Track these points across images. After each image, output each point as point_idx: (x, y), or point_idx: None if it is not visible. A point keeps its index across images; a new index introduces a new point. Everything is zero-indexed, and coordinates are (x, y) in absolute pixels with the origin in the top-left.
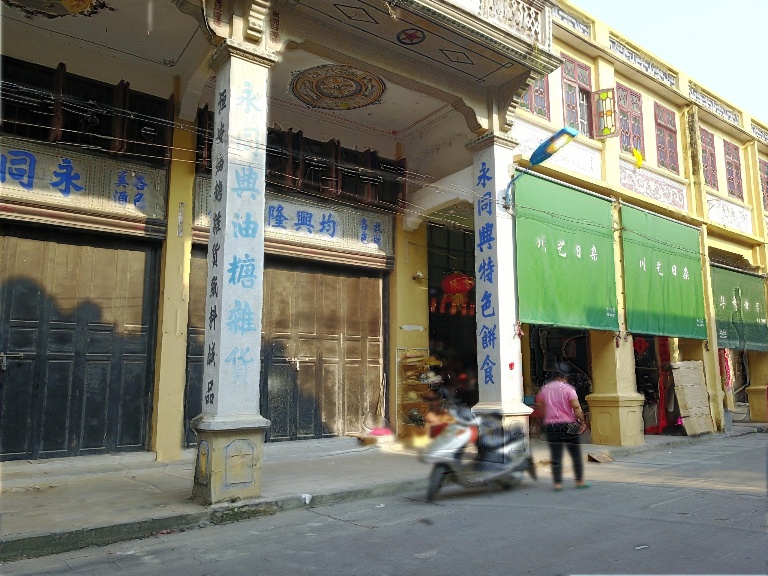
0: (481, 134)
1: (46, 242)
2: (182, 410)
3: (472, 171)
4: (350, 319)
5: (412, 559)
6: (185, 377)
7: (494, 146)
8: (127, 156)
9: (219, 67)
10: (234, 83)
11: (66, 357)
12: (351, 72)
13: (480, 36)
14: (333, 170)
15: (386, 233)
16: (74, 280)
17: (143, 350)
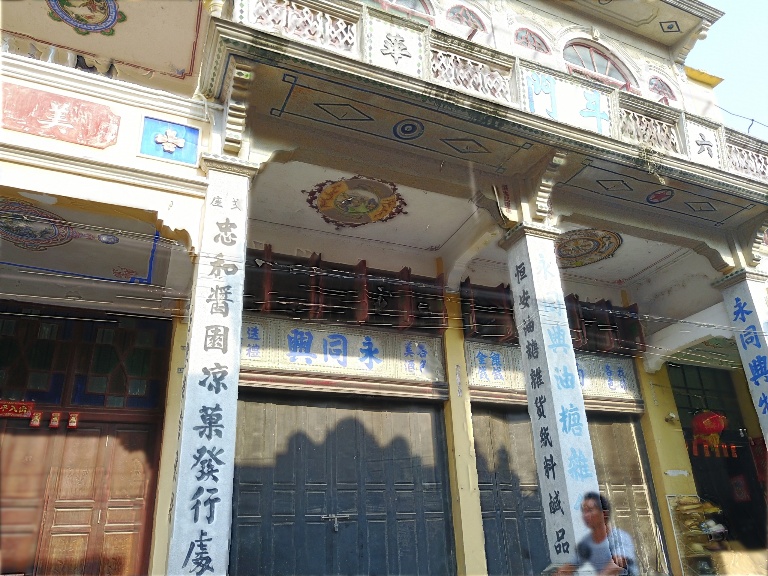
0: (728, 272)
1: (356, 411)
2: (486, 568)
3: (723, 307)
4: (611, 467)
5: None
6: (483, 533)
7: (747, 281)
8: (411, 329)
9: (511, 245)
10: (532, 256)
11: (381, 517)
12: (593, 234)
13: (725, 186)
14: (577, 322)
15: (629, 377)
16: (379, 443)
17: (440, 508)
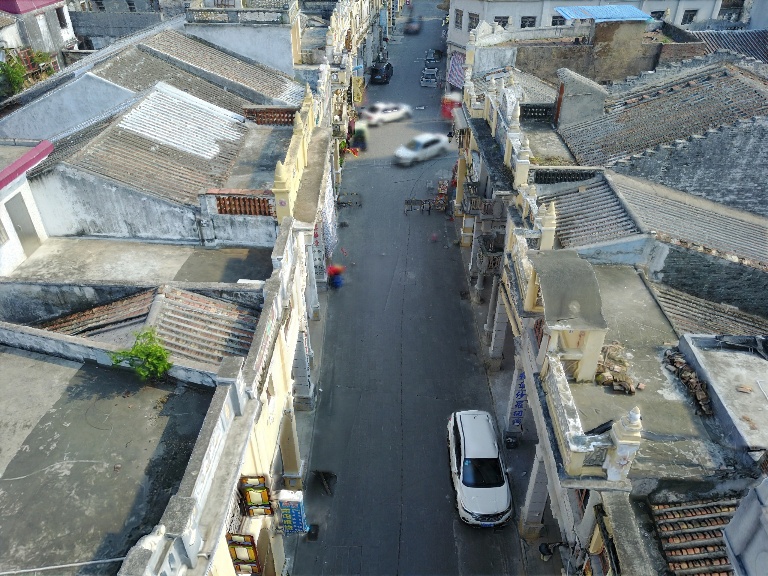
0: None
1: None
2: None
3: None
4: None
5: None
6: None
7: None
8: None
9: None
10: None
11: None
12: None
13: None
14: None
15: None
16: None
17: None
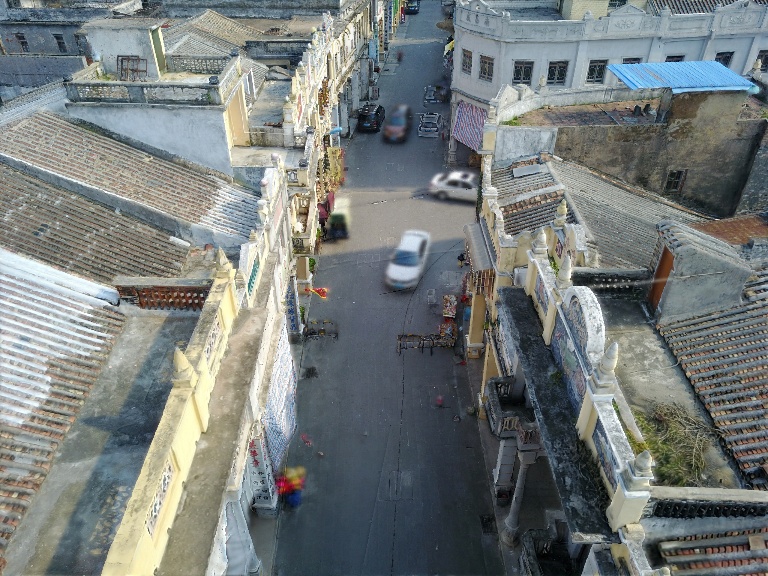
0: None
1: None
2: None
3: None
4: None
5: None
6: None
7: None
8: None
9: None
10: None
11: None
12: None
13: None
14: None
15: None
16: None
17: None
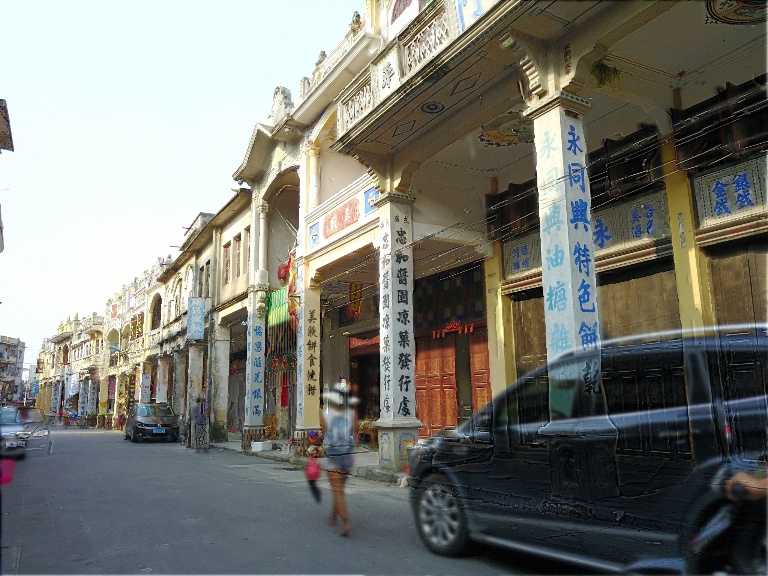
0: None
1: (607, 285)
2: (712, 422)
3: None
4: None
5: (424, 542)
6: (710, 388)
7: None
8: (632, 195)
9: None
10: (538, 141)
11: (631, 373)
12: None
13: None
14: None
15: None
16: (628, 310)
17: None
